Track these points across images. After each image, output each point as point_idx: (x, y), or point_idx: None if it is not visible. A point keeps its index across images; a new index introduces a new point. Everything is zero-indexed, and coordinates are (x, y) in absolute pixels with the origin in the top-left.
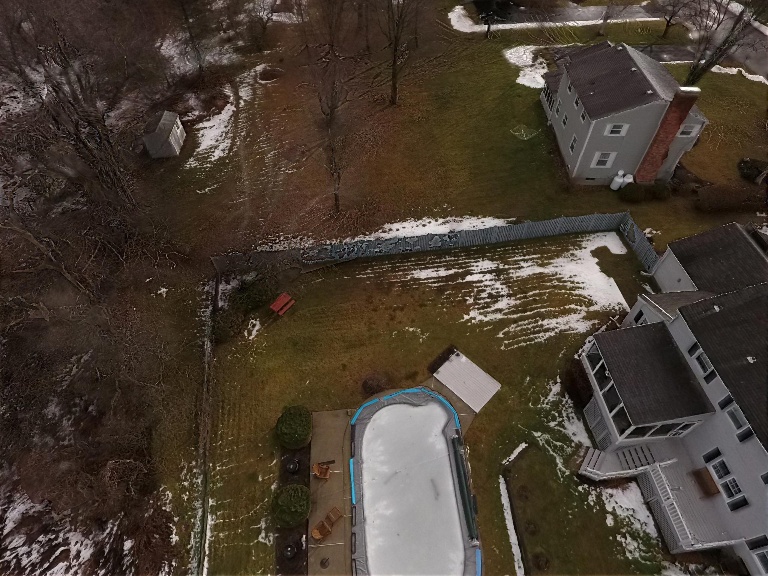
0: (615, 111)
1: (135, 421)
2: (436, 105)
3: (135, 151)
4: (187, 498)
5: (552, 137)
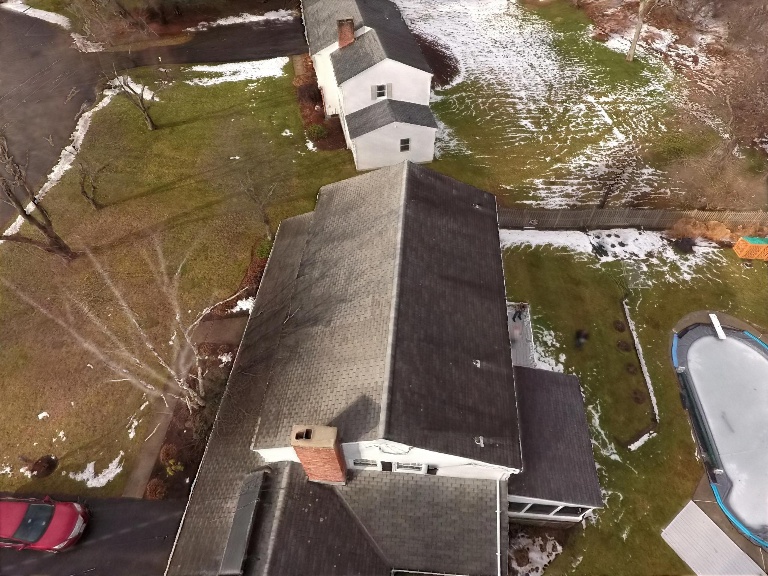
0: None
1: None
2: None
3: None
4: None
5: None
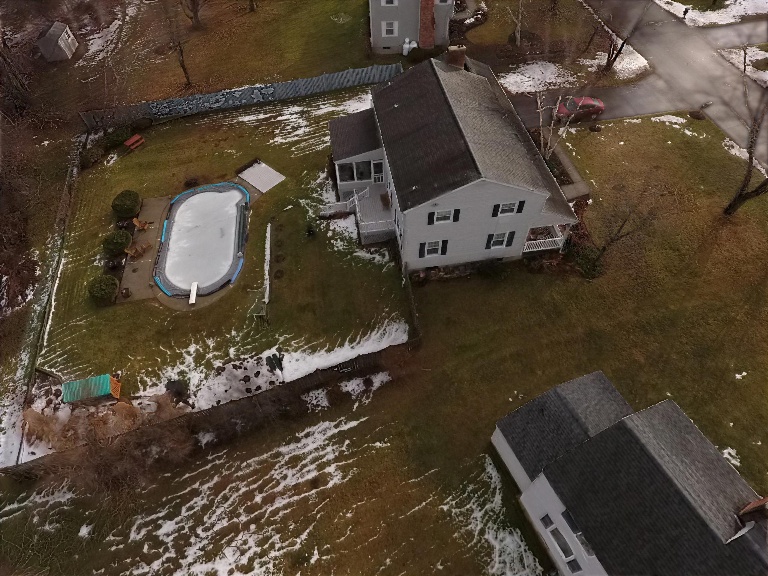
0: None
1: None
2: (287, 10)
3: (34, 57)
4: (49, 252)
5: (369, 24)
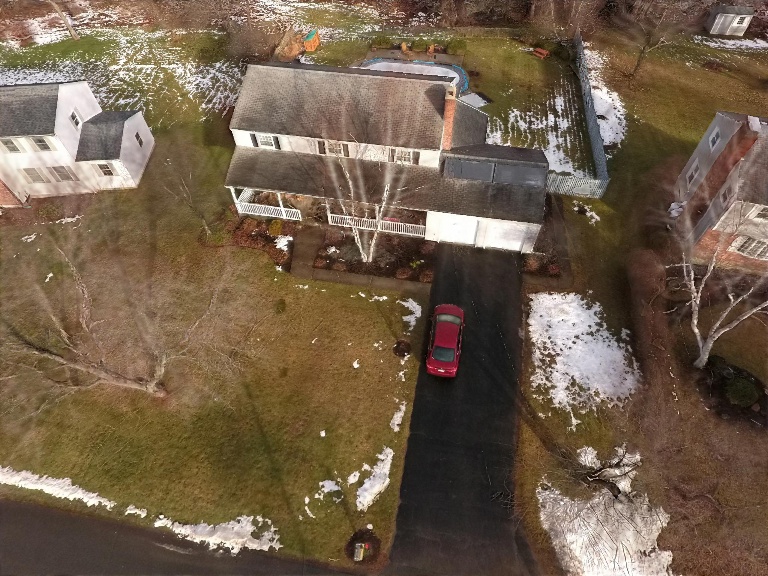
0: (729, 114)
1: (479, 25)
2: None
3: None
4: None
5: None
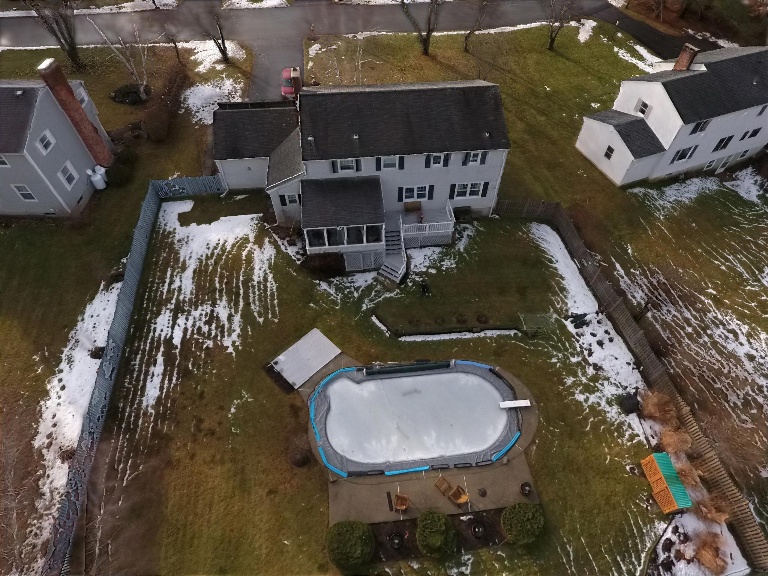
0: (25, 128)
1: None
2: None
3: None
4: None
5: None
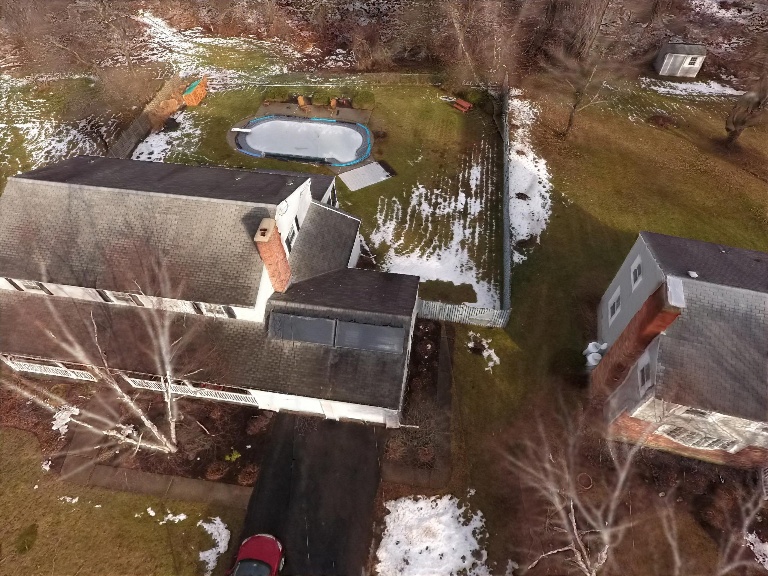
0: (653, 244)
1: (399, 67)
2: None
3: None
4: None
5: None
